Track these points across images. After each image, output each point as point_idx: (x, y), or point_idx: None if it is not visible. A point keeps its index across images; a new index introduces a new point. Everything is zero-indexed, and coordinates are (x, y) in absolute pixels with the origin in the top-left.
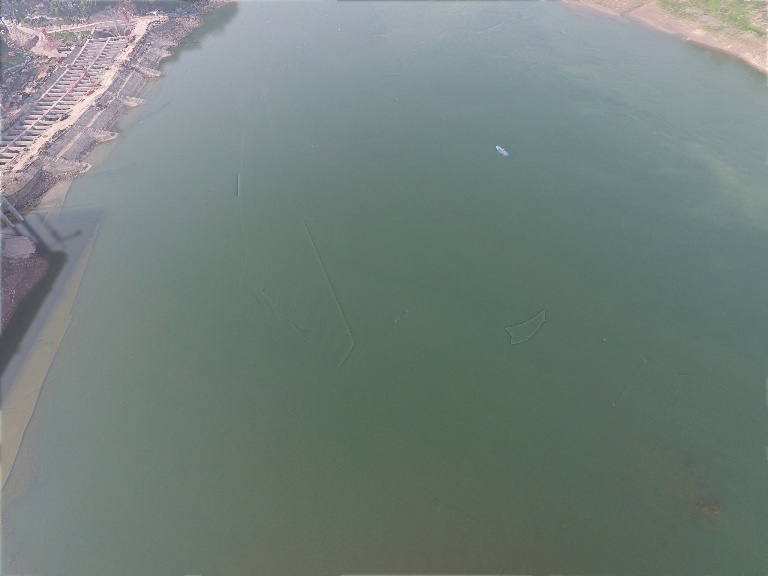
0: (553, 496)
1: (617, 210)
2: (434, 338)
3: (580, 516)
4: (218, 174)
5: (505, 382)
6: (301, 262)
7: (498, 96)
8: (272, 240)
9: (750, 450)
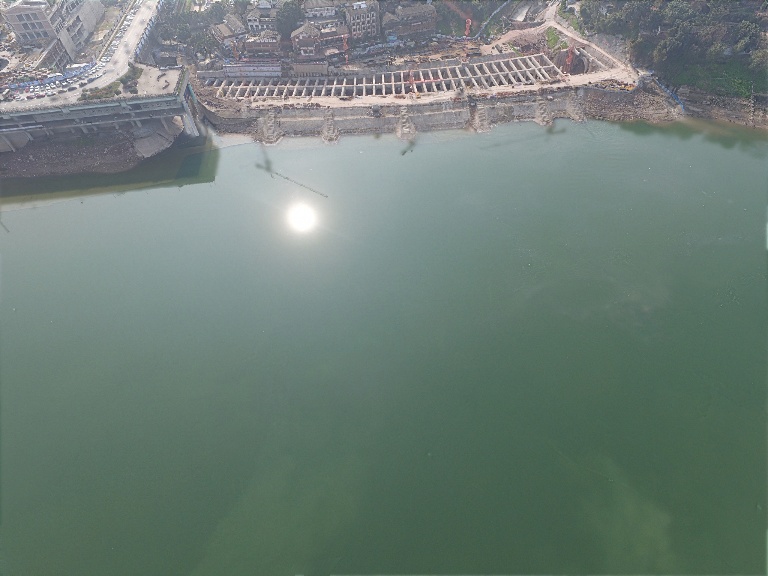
0: None
1: None
2: None
3: None
4: (154, 240)
5: None
6: None
7: None
8: None
9: None
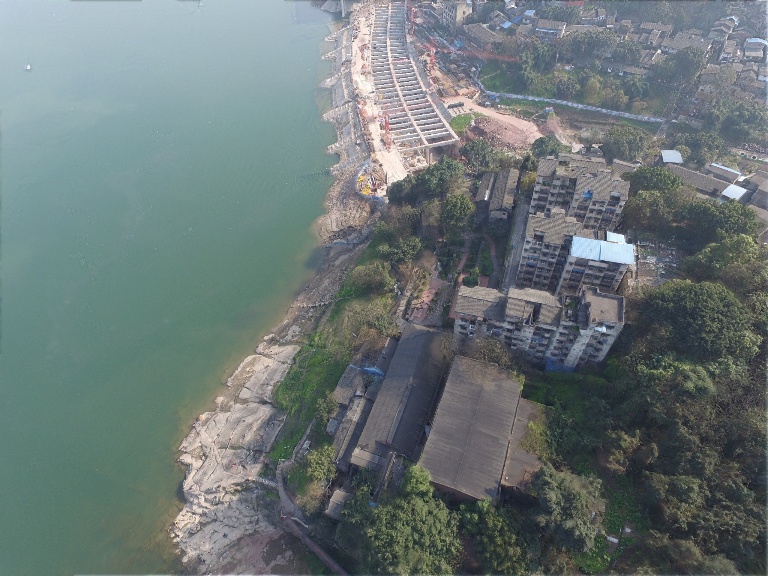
0: None
1: (10, 30)
2: None
3: None
4: (215, 12)
5: None
6: None
7: None
8: None
9: None
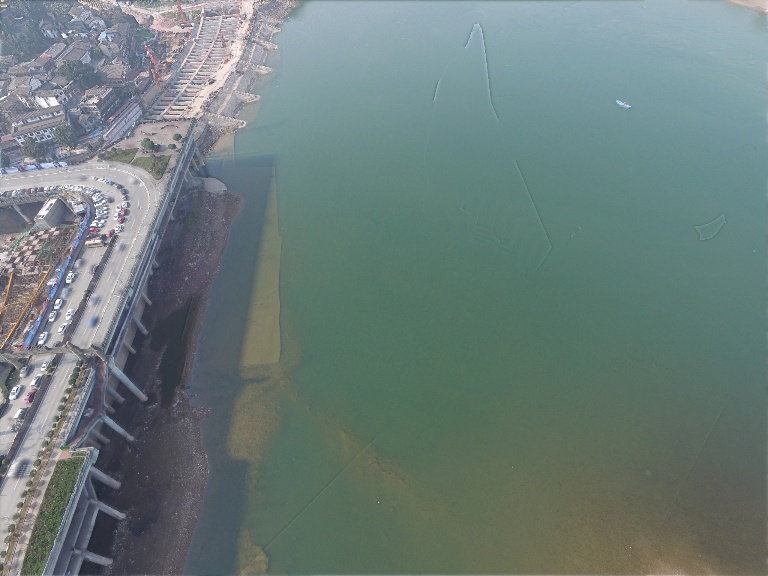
0: (742, 364)
1: (749, 147)
2: (608, 249)
3: None
4: (382, 122)
5: (678, 282)
6: (502, 180)
7: (601, 61)
8: (472, 164)
9: None
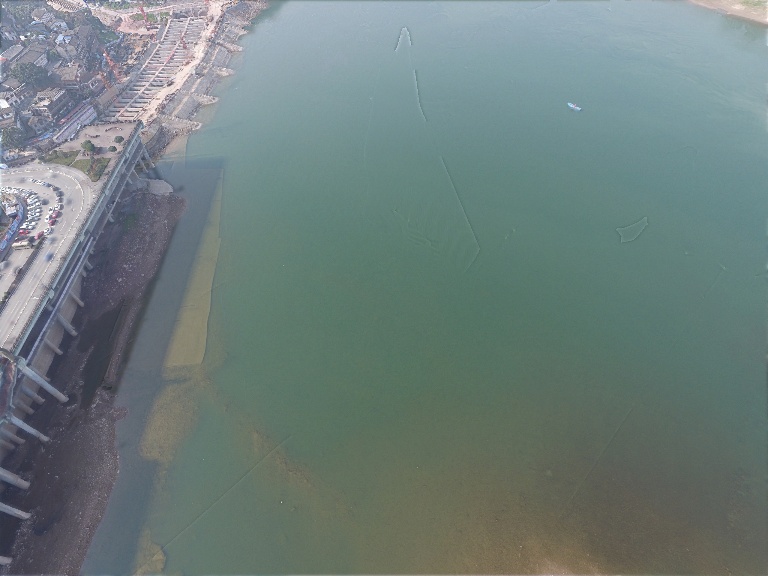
0: (660, 365)
1: (688, 149)
2: (540, 251)
3: (685, 378)
4: (329, 124)
5: (606, 284)
6: (432, 183)
7: (559, 63)
8: (404, 166)
9: None
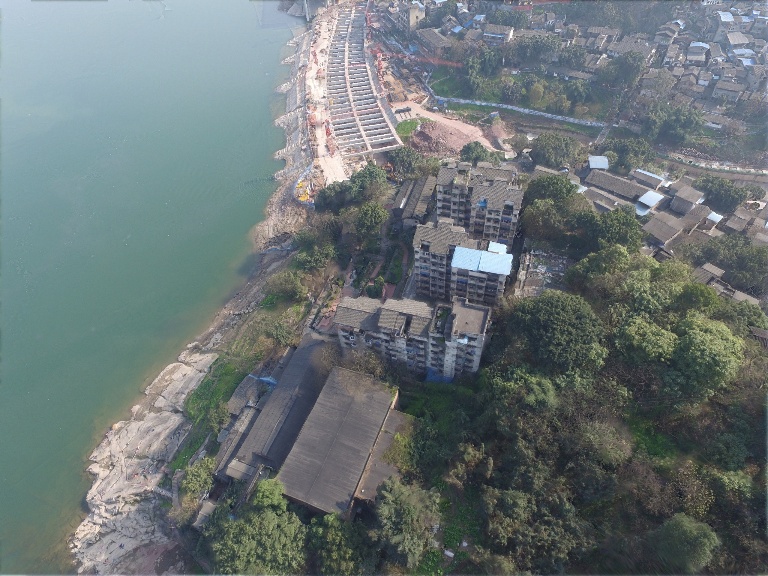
0: None
1: None
2: None
3: None
4: (178, 17)
5: None
6: None
7: None
8: None
9: (26, 3)
